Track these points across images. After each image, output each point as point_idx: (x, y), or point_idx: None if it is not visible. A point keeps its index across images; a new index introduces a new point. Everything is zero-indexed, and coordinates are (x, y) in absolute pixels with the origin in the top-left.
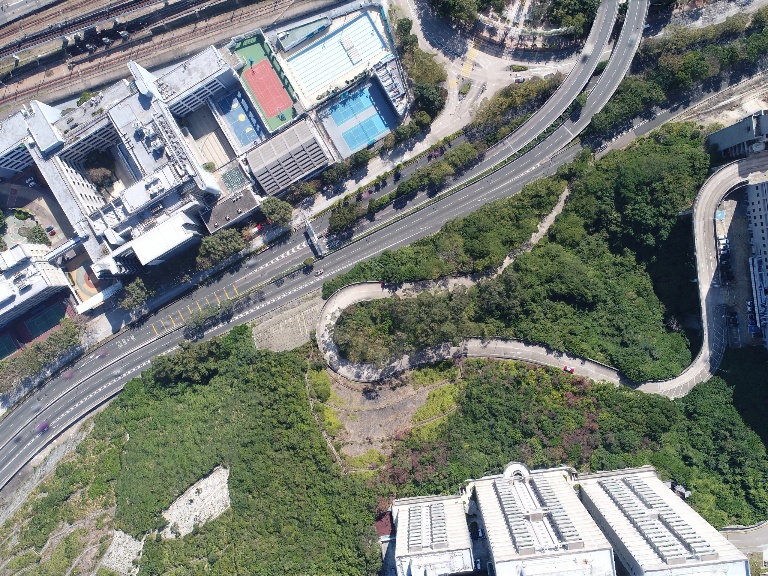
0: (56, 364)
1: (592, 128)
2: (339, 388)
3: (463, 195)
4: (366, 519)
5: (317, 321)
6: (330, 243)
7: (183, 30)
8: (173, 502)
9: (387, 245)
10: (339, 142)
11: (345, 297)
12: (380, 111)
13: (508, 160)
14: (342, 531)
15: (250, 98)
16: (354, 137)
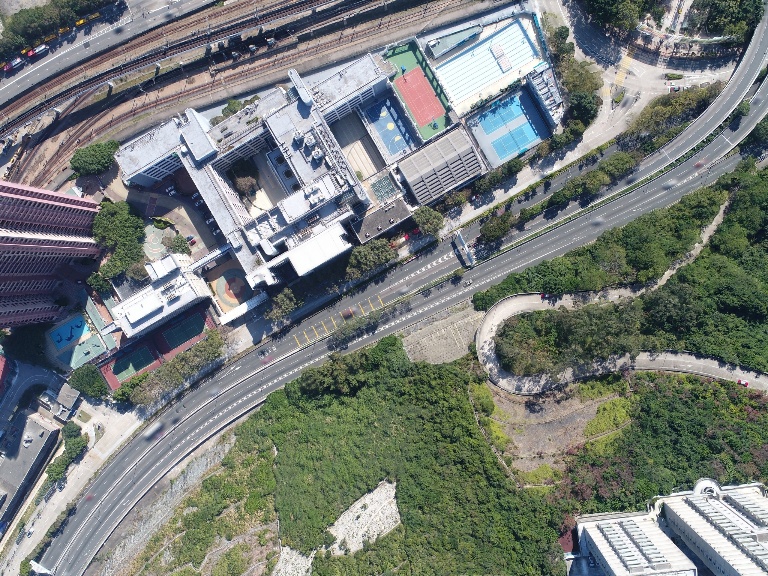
0: (195, 375)
1: (753, 137)
2: (501, 401)
3: (618, 205)
4: (550, 536)
5: (477, 333)
6: (478, 253)
7: (329, 37)
8: (338, 518)
9: (538, 255)
10: (488, 151)
11: (505, 309)
12: (531, 120)
13: (665, 170)
14: (522, 548)
15: (404, 106)
16: (504, 146)
